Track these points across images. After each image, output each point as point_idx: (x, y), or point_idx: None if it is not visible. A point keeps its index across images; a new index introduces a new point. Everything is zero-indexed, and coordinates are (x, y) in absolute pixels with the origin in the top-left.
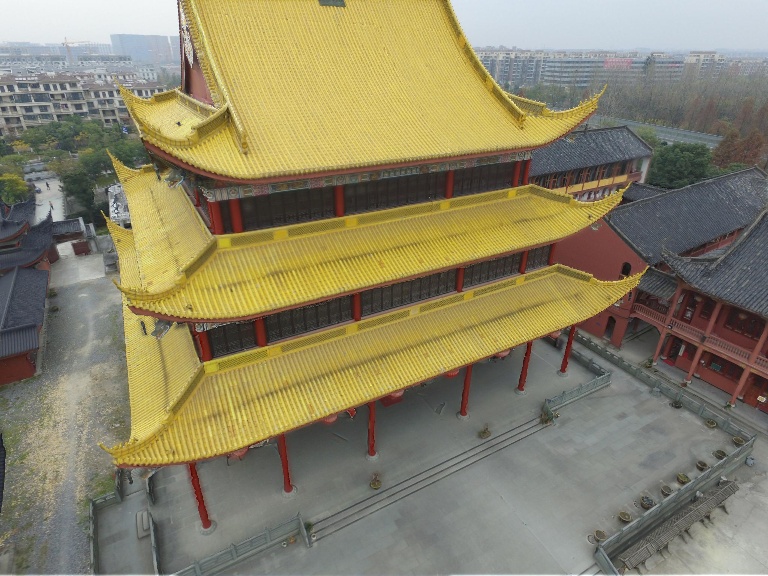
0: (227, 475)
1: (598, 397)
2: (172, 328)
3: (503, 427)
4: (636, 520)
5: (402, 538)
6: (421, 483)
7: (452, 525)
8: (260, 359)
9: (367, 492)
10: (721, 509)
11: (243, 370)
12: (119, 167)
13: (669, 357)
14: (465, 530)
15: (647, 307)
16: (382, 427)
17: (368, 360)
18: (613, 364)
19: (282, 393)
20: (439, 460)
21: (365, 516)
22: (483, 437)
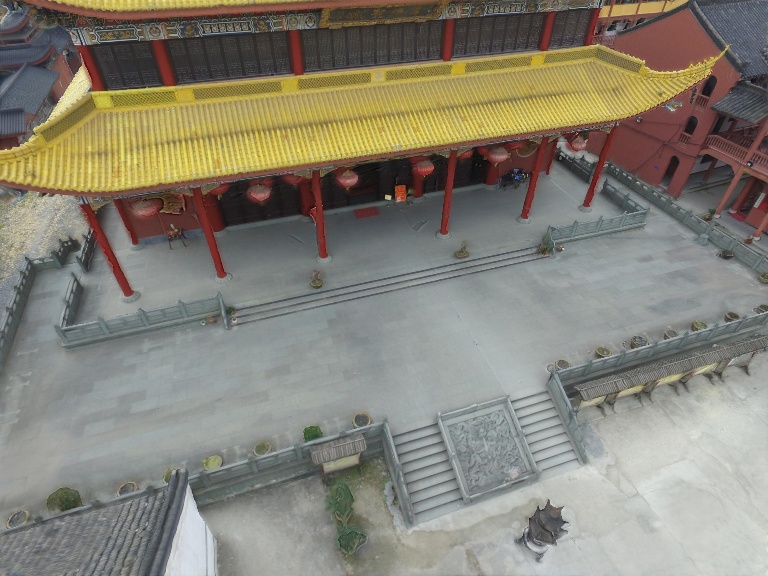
0: (167, 257)
1: (623, 237)
2: None
3: (487, 251)
4: (614, 355)
5: (329, 336)
6: (370, 290)
7: (390, 332)
8: (167, 103)
9: (305, 289)
10: (741, 369)
11: (145, 113)
12: None
13: (740, 211)
14: (403, 339)
15: (725, 139)
16: (346, 235)
17: (304, 124)
18: (658, 208)
19: (187, 143)
20: (398, 272)
21: (297, 311)
22: (458, 256)
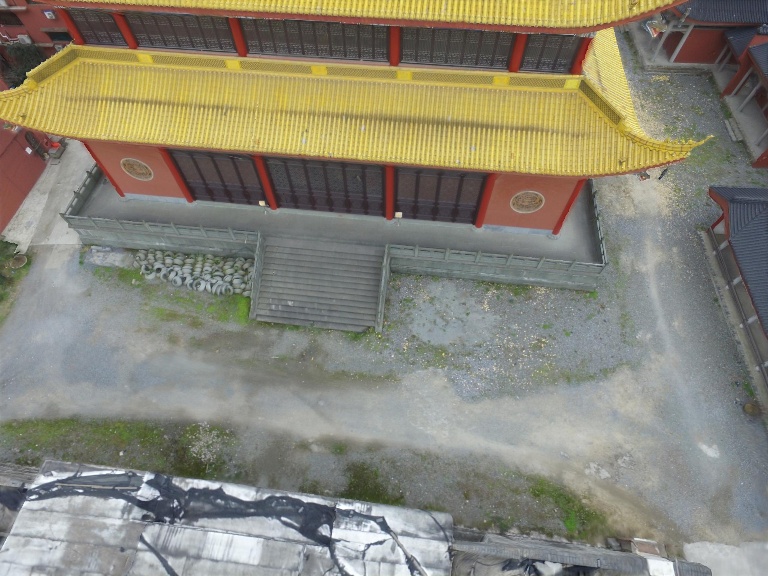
0: None
1: None
2: None
3: None
4: None
5: None
6: None
7: None
8: None
9: None
10: None
11: None
12: None
13: None
14: None
15: None
16: None
17: None
18: None
19: None
20: None
21: None
22: None
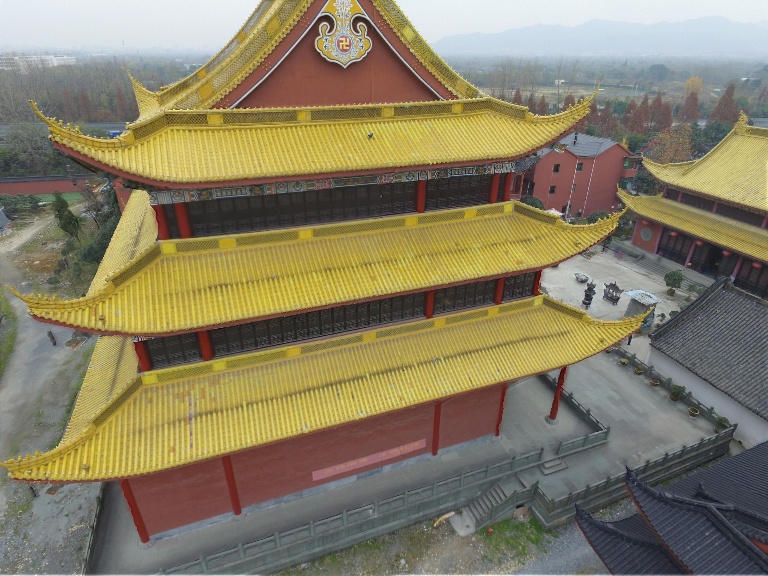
0: None
1: None
2: (459, 339)
3: None
4: None
5: None
6: None
7: None
8: None
9: None
10: None
11: None
12: (51, 310)
13: None
14: None
15: None
16: None
17: None
18: None
19: None
20: None
21: None
22: None
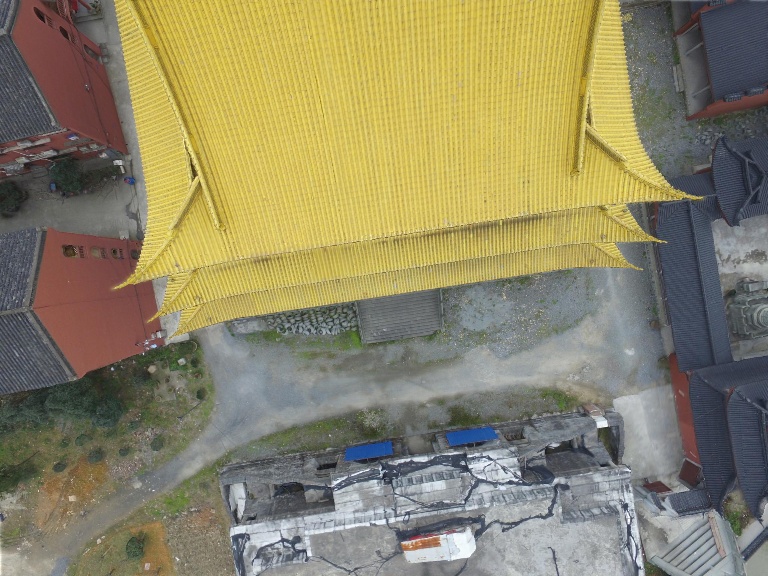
0: None
1: None
2: None
3: None
4: None
5: None
6: None
7: None
8: None
9: None
10: None
11: None
12: None
13: None
14: None
15: None
16: None
17: None
18: None
19: None
20: None
21: None
22: None
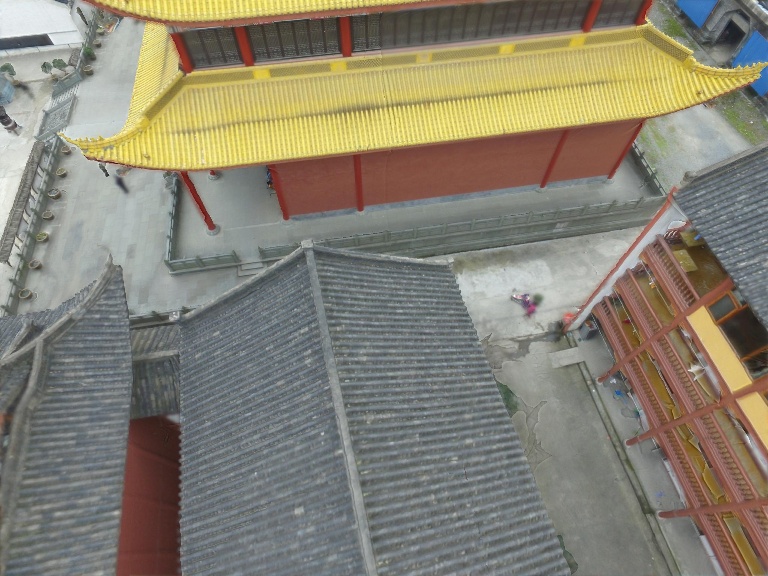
0: None
1: None
2: None
3: None
4: (47, 166)
5: None
6: None
7: None
8: None
9: None
10: None
11: None
12: None
13: None
14: None
15: None
16: None
17: None
18: None
19: None
20: None
21: None
22: None
